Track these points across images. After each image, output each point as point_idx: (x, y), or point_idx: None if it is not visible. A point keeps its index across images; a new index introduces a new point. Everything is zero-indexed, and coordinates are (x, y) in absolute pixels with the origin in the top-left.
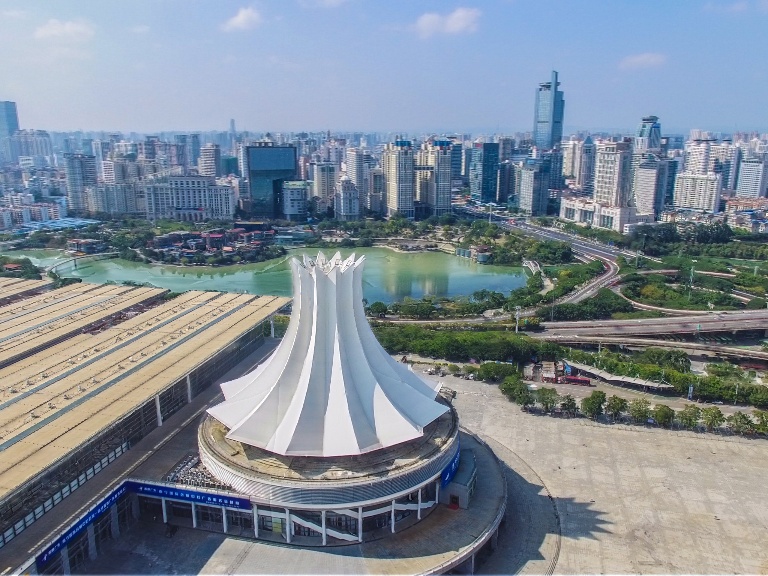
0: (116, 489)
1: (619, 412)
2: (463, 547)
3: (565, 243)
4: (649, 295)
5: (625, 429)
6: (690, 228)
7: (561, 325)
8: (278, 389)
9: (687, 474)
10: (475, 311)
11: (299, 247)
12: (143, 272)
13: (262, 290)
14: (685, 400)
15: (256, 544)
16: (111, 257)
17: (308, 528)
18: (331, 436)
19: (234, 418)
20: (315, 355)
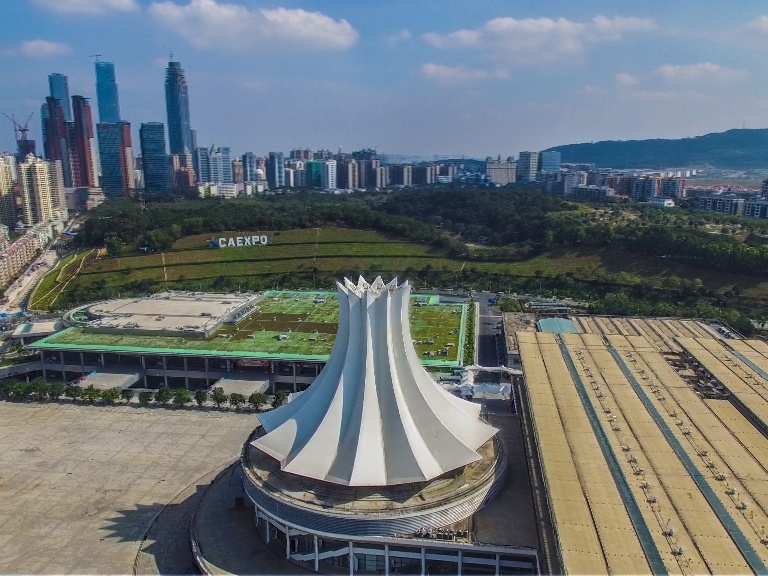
0: None
1: None
2: None
3: None
4: None
5: None
6: None
7: None
8: None
9: None
10: None
11: None
12: None
13: None
14: None
15: None
16: None
17: None
18: None
19: None
20: None
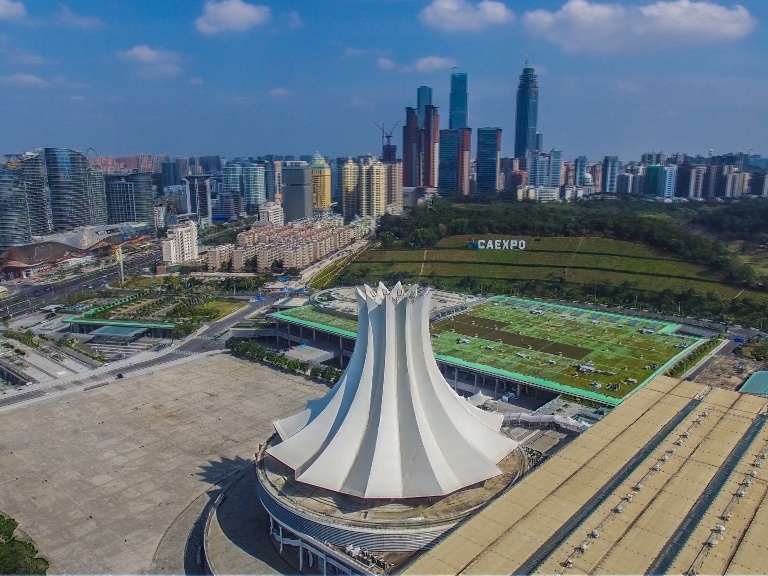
0: None
1: None
2: None
3: None
4: None
5: None
6: None
7: None
8: None
9: (84, 471)
10: None
11: None
12: None
13: None
14: None
15: None
16: None
17: None
18: None
19: None
20: None
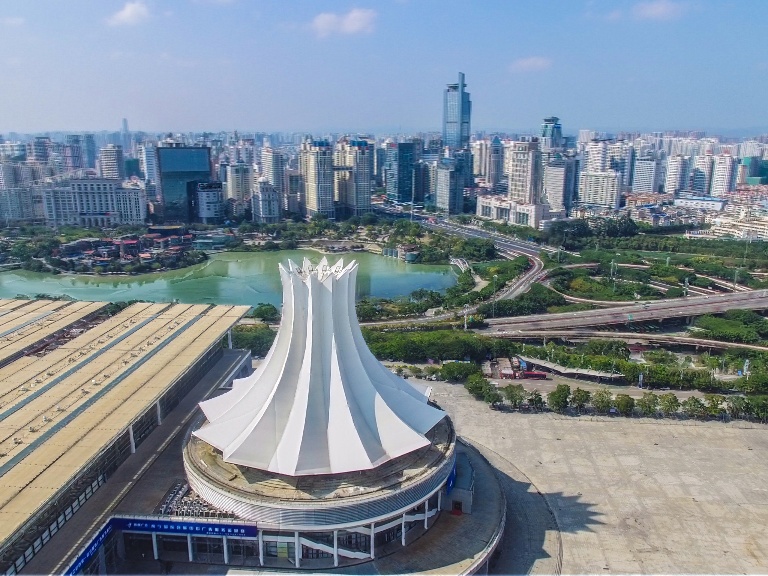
0: (102, 528)
1: (583, 404)
2: (477, 553)
3: (488, 240)
4: (578, 288)
5: (591, 420)
6: (600, 223)
7: (503, 321)
8: (274, 405)
9: (658, 460)
10: (418, 311)
11: (220, 251)
12: (52, 283)
13: (190, 298)
14: (636, 388)
15: (263, 573)
16: (12, 268)
17: (317, 550)
18: (337, 451)
19: (225, 439)
20: (312, 367)
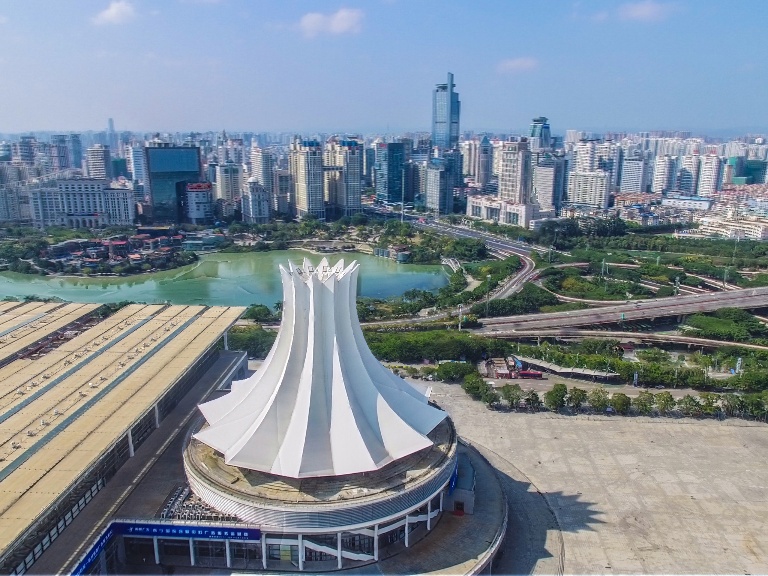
0: (103, 533)
1: (580, 403)
2: (481, 554)
3: (480, 240)
4: (570, 288)
5: (588, 419)
6: (590, 223)
7: (496, 321)
8: (276, 407)
9: (655, 458)
10: (411, 311)
11: (211, 252)
12: (41, 285)
13: (181, 299)
14: (631, 387)
15: (267, 575)
16: None
17: (320, 552)
18: (340, 453)
19: (226, 442)
20: (314, 368)
